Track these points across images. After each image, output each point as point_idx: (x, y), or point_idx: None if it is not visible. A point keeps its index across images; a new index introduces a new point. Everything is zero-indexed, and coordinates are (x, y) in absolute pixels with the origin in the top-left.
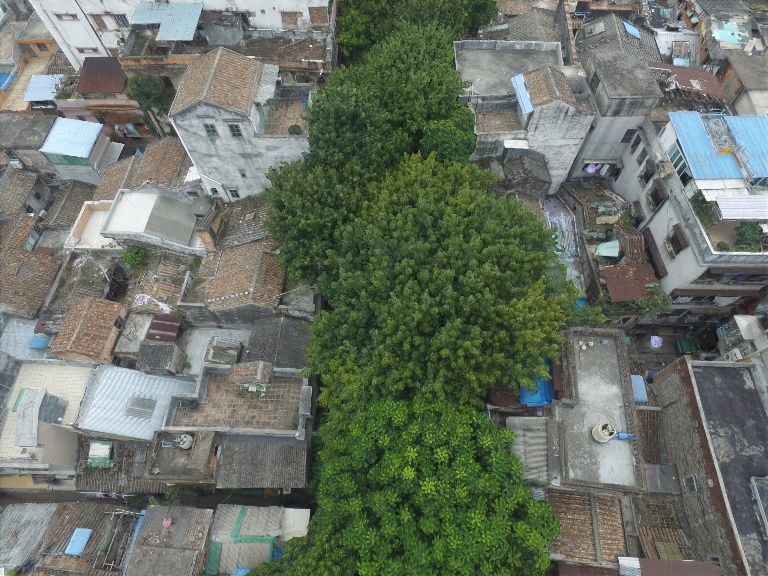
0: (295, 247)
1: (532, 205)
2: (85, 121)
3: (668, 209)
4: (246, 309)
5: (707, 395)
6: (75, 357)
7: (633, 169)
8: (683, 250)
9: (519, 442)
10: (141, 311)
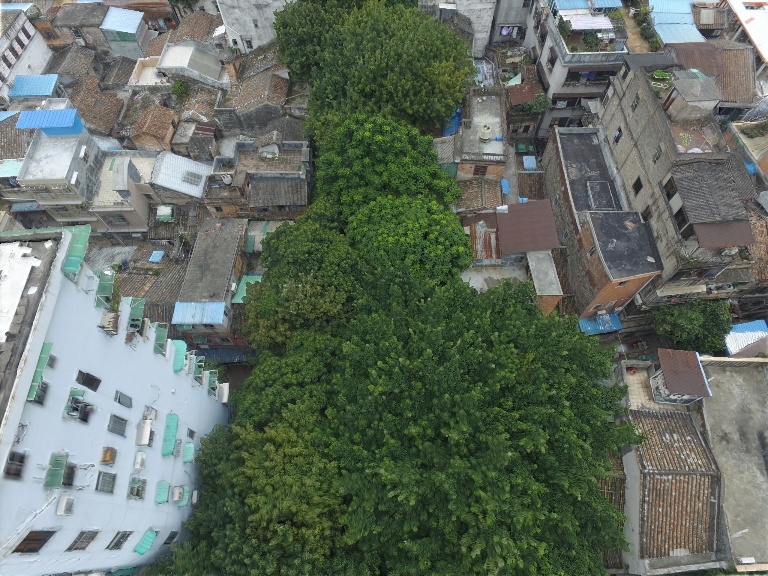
0: (295, 52)
1: None
2: (130, 10)
3: (548, 39)
4: (262, 111)
5: (568, 148)
6: (146, 142)
7: (532, 25)
8: (555, 62)
9: (438, 149)
10: (188, 119)
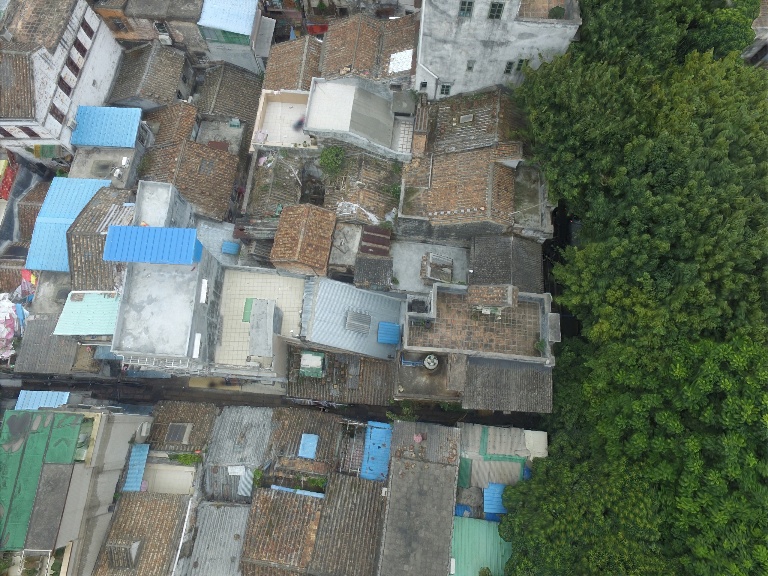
0: None
1: None
2: None
3: None
4: (474, 226)
5: None
6: (294, 268)
7: None
8: None
9: None
10: (351, 221)
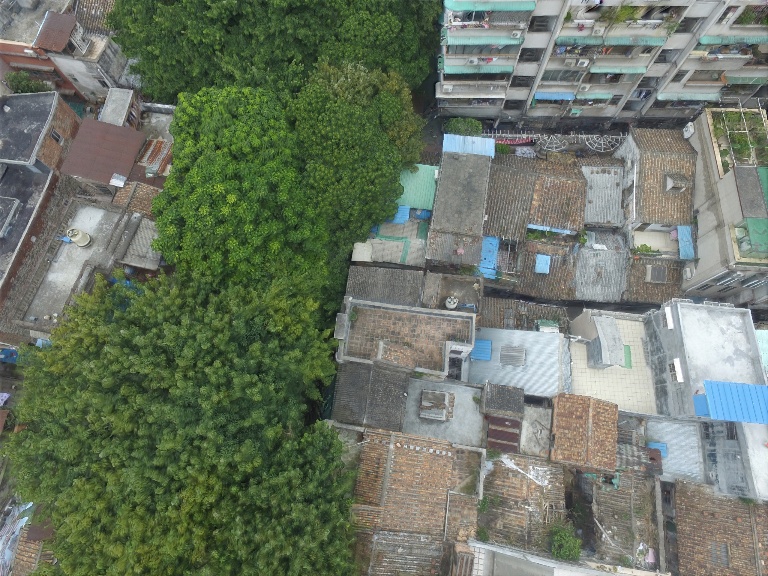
0: None
1: (20, 574)
2: None
3: None
4: None
5: None
6: None
7: None
8: None
9: None
10: (534, 457)
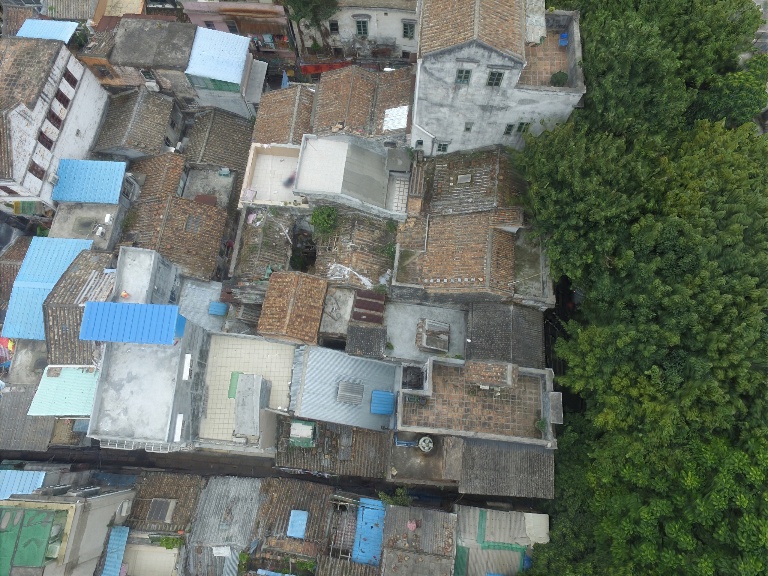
0: None
1: None
2: (229, 33)
3: None
4: (472, 295)
5: None
6: (283, 338)
7: None
8: None
9: None
10: (343, 286)
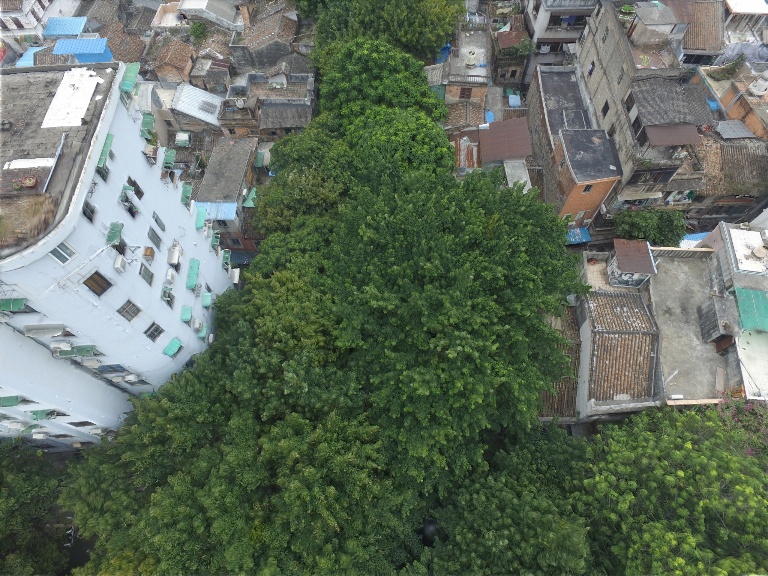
0: None
1: None
2: None
3: None
4: (272, 48)
5: (548, 84)
6: (168, 73)
7: None
8: (540, 8)
9: (429, 75)
10: (205, 56)
